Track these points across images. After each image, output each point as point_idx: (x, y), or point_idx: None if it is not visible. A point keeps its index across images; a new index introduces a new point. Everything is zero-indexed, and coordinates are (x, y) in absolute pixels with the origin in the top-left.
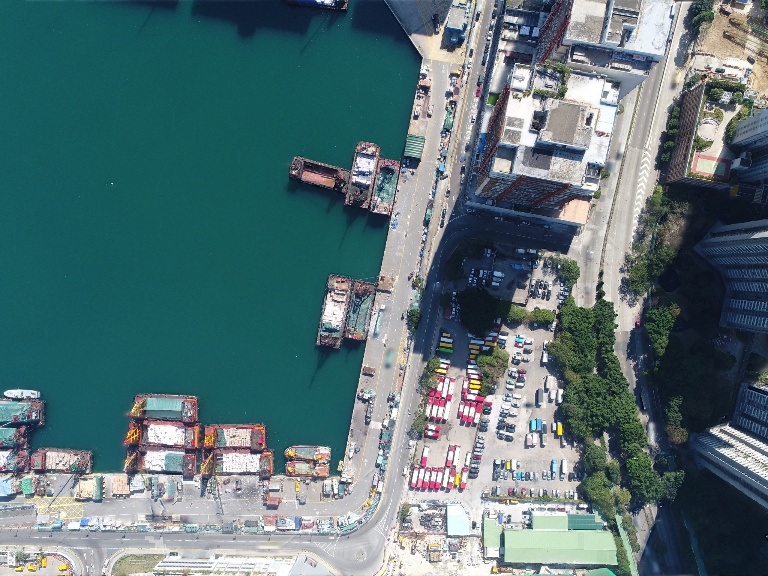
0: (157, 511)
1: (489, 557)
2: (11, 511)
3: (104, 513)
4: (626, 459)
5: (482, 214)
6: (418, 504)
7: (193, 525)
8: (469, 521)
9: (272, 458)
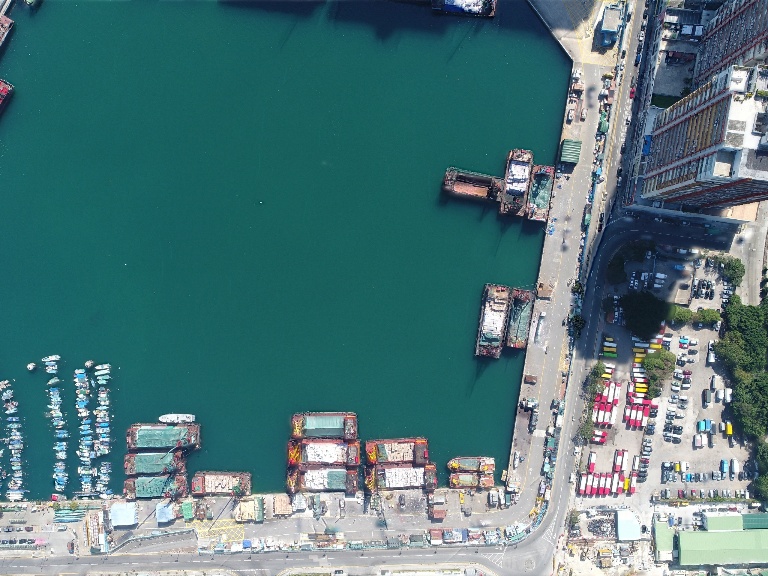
0: (320, 529)
1: (662, 560)
2: (171, 536)
3: (266, 534)
4: None
5: (642, 216)
6: (586, 510)
7: (358, 542)
8: (639, 525)
9: None
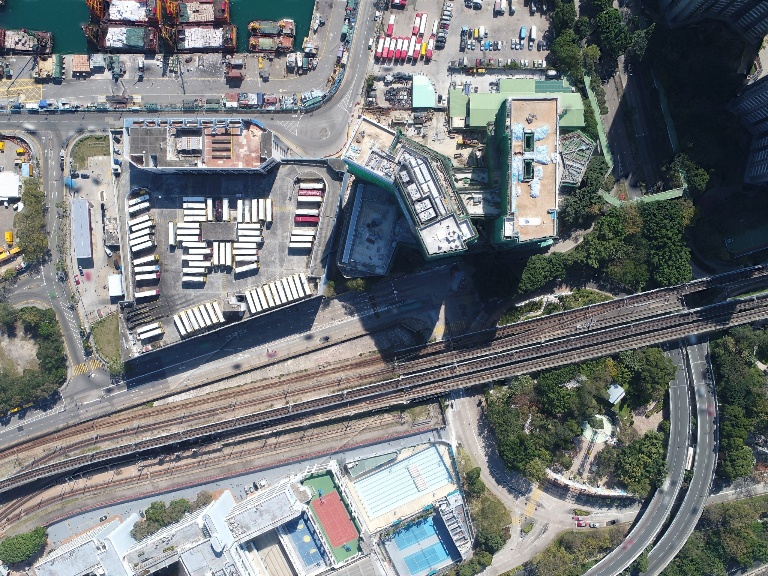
0: (117, 92)
1: (454, 128)
2: None
3: (64, 95)
4: (596, 25)
5: None
6: (383, 77)
7: (154, 103)
8: (435, 95)
9: (235, 33)
